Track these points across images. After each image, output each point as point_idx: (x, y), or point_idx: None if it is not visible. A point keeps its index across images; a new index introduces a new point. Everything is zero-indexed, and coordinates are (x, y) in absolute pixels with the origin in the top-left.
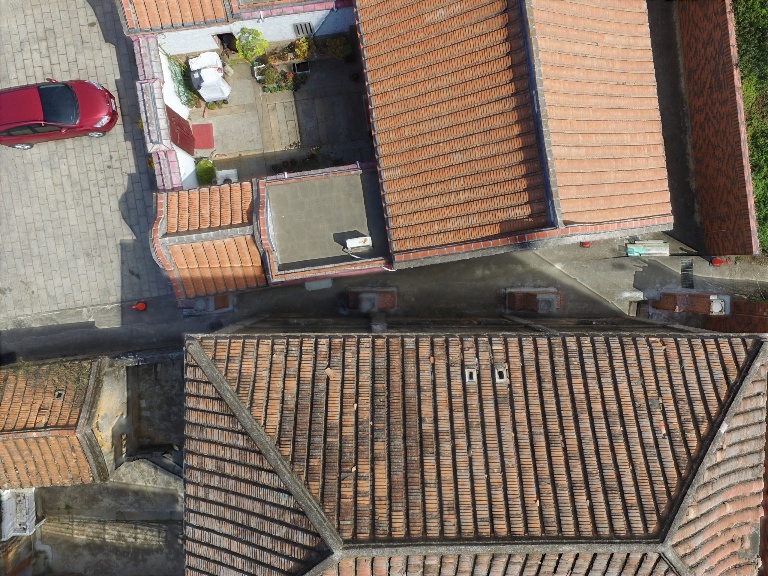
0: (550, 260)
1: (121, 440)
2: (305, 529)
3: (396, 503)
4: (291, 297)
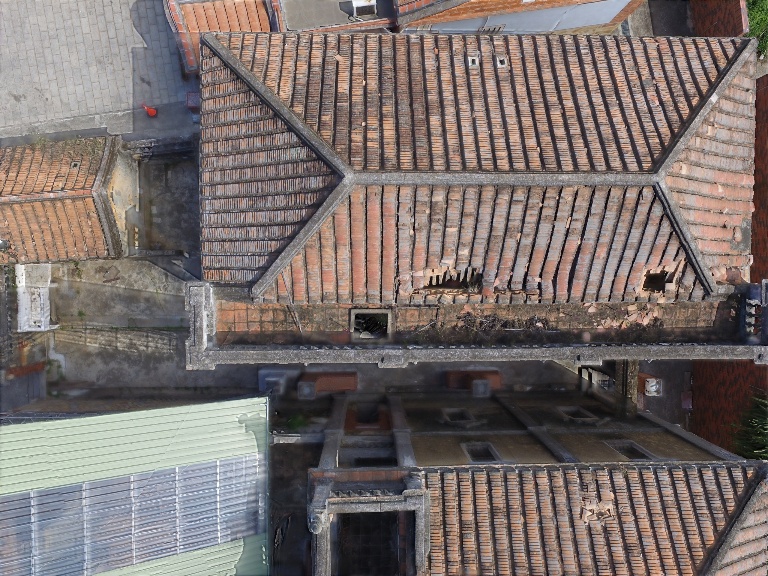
0: None
1: (134, 231)
2: (318, 175)
3: (404, 146)
4: None
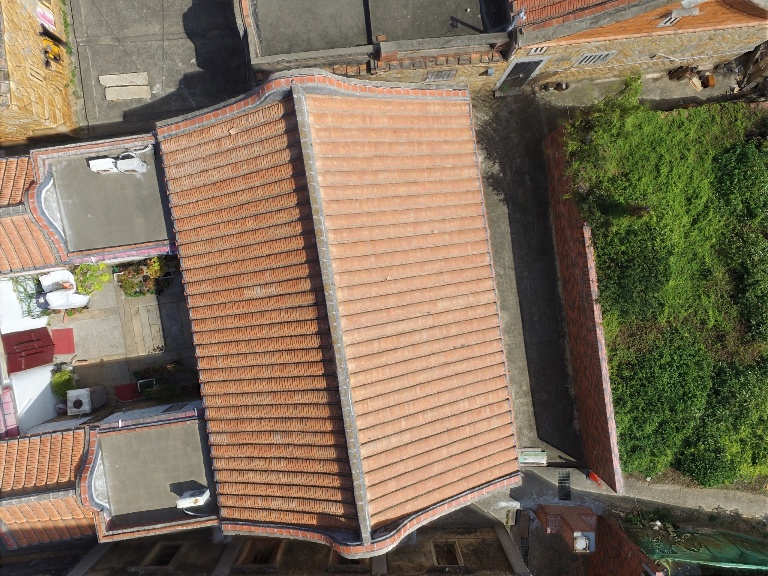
0: None
1: None
2: None
3: None
4: None
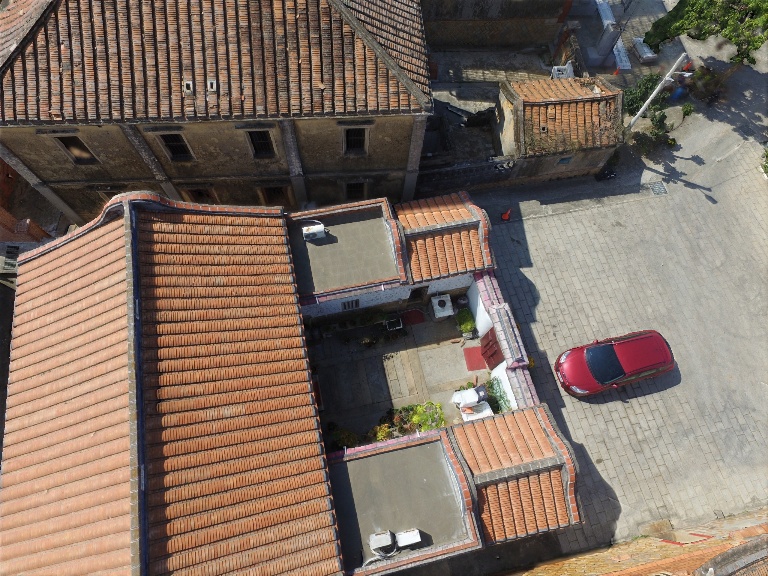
0: None
1: None
2: None
3: None
4: None
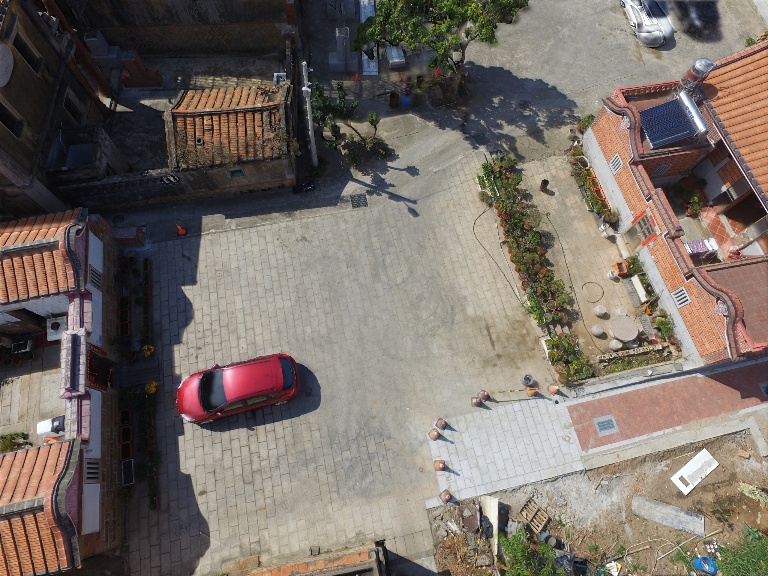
0: None
1: None
2: None
3: None
4: None
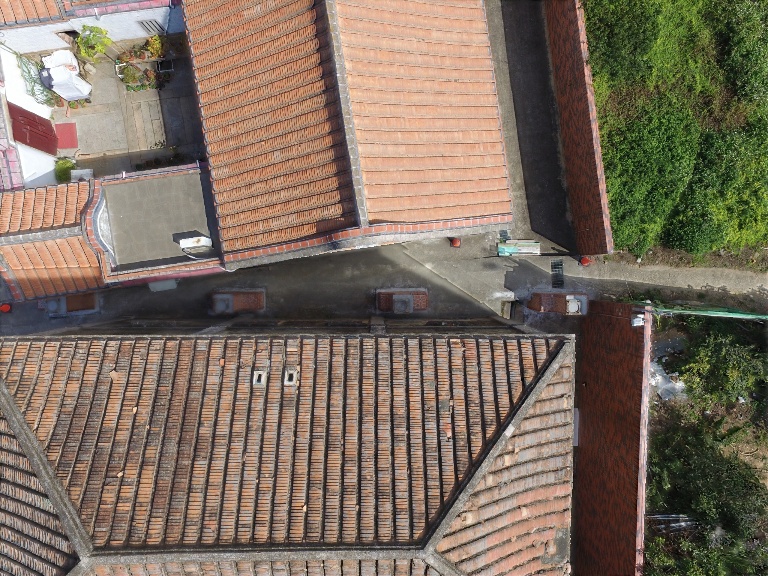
0: (420, 260)
1: None
2: (66, 536)
3: (157, 509)
4: (158, 298)
